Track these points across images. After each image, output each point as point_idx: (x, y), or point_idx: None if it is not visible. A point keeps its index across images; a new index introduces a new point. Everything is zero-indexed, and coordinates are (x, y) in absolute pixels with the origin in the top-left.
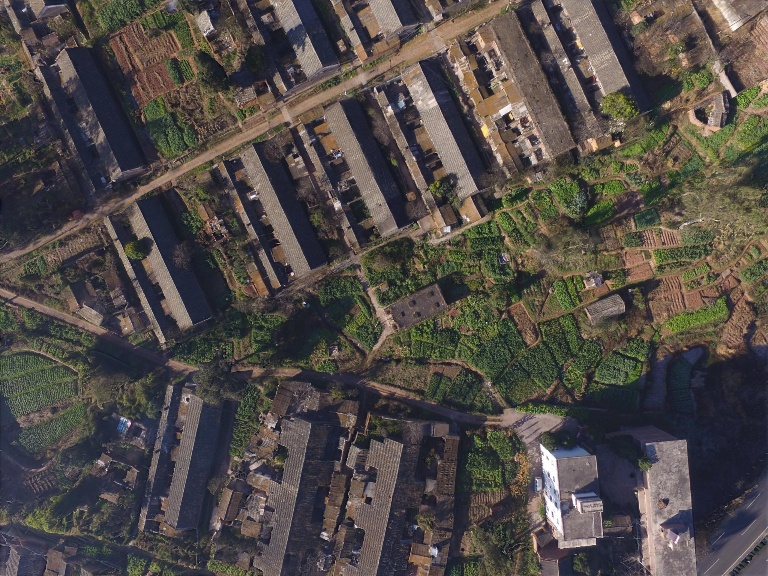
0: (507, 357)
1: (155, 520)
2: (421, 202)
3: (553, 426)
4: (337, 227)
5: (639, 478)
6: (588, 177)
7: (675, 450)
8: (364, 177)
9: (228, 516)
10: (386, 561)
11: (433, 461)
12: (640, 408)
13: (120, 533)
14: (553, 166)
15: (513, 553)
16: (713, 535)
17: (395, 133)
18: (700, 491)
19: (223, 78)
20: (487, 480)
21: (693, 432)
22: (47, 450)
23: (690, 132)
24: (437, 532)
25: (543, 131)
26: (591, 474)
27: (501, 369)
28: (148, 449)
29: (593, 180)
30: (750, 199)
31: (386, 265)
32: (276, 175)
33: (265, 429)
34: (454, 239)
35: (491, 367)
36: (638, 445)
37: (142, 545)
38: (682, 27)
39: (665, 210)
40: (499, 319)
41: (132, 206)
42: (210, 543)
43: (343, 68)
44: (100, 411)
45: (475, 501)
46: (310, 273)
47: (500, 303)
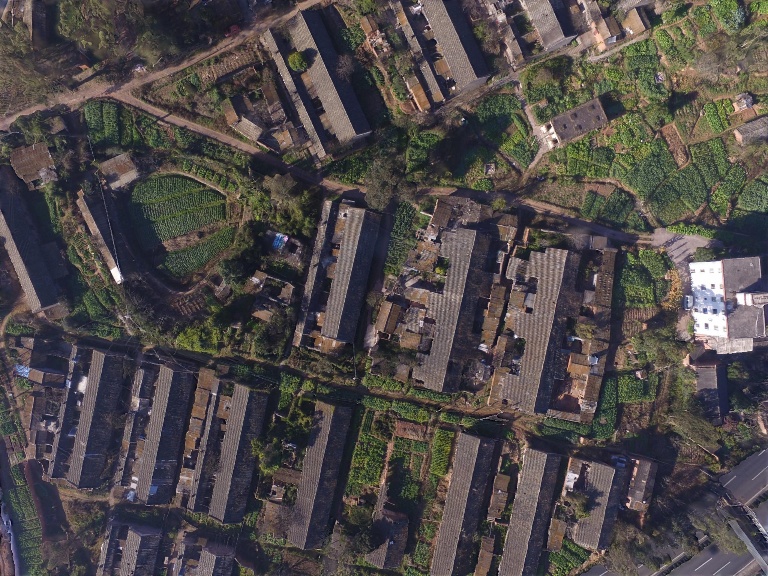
0: (660, 176)
1: (310, 336)
2: None
3: None
4: (500, 40)
5: None
6: None
7: None
8: None
9: (387, 328)
10: (548, 367)
11: None
12: None
13: (274, 350)
14: None
15: (663, 369)
16: None
17: None
18: None
19: None
20: (639, 297)
21: None
22: (193, 275)
23: None
24: (595, 342)
25: None
26: (755, 275)
27: (654, 188)
28: (303, 266)
29: None
30: None
31: (549, 78)
32: None
33: (424, 243)
34: (612, 57)
35: (645, 185)
36: None
37: (295, 364)
38: None
39: None
40: (652, 139)
41: (295, 17)
42: (365, 359)
43: None
44: (253, 229)
45: (628, 317)
46: (469, 90)
47: (661, 115)
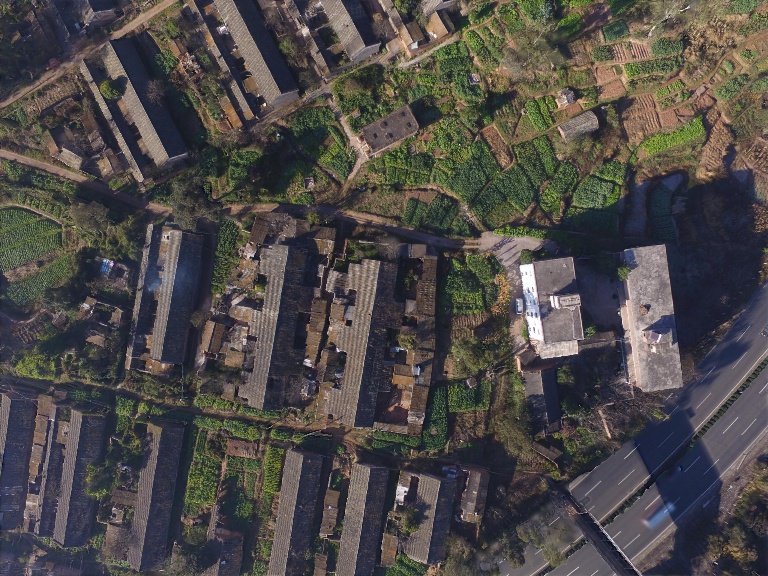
0: (482, 179)
1: (141, 359)
2: (388, 25)
3: (532, 249)
4: (306, 54)
5: (621, 294)
6: None
7: (654, 255)
8: None
9: (212, 348)
10: (369, 380)
11: (413, 285)
12: (620, 232)
13: (107, 375)
14: None
15: (497, 376)
16: (704, 369)
17: None
18: (687, 318)
19: None
20: (468, 303)
21: (676, 259)
22: (35, 303)
23: None
24: (419, 352)
25: None
26: (569, 276)
27: (477, 191)
28: (131, 290)
29: None
30: None
31: (356, 88)
32: (244, 5)
33: (245, 261)
34: (423, 62)
35: (466, 189)
36: (617, 257)
37: (130, 387)
38: None
39: (633, 21)
40: (472, 142)
41: (105, 46)
42: (196, 379)
43: None
44: (84, 256)
45: (456, 324)
46: (283, 106)
47: (471, 118)
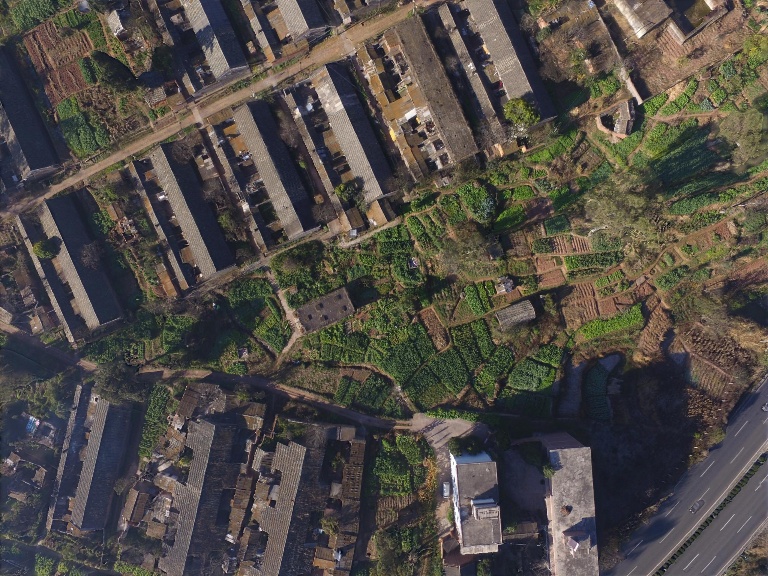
0: (416, 361)
1: (62, 520)
2: (330, 205)
3: (463, 431)
4: (245, 229)
5: (547, 485)
6: (497, 182)
7: (579, 457)
8: (271, 179)
9: (134, 517)
10: (288, 564)
11: (340, 465)
12: (553, 414)
13: (28, 532)
14: (457, 171)
15: (420, 558)
16: (631, 543)
17: (303, 136)
18: (615, 498)
19: (127, 78)
20: (395, 485)
21: (609, 439)
22: None
23: (598, 139)
24: (341, 536)
25: (446, 136)
26: (491, 480)
27: (410, 373)
28: (57, 449)
29: (502, 185)
30: (636, 207)
31: (293, 268)
32: (184, 176)
33: (172, 430)
34: (364, 242)
35: (400, 371)
36: (545, 452)
37: (50, 545)
38: (587, 33)
39: (575, 216)
40: (409, 323)
41: (41, 205)
42: (117, 544)
43: (254, 70)
44: (10, 410)
45: (382, 505)
46: (220, 275)
47: (406, 307)
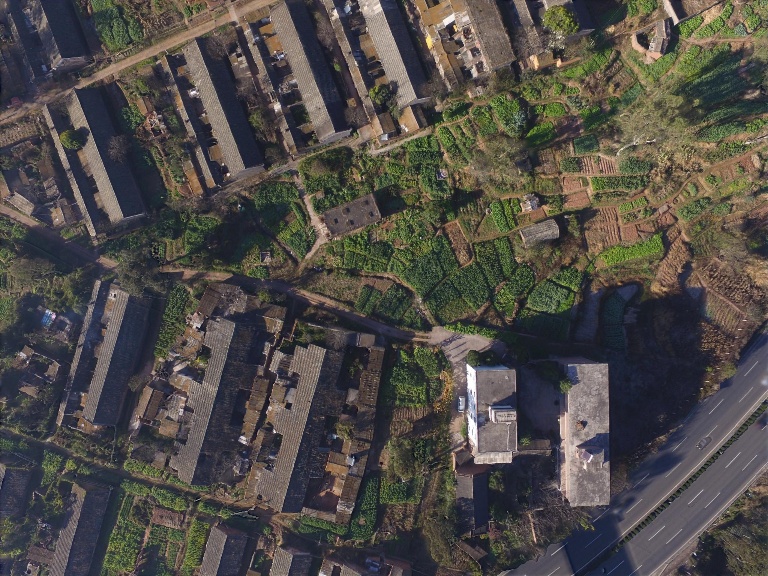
0: (439, 274)
1: (74, 416)
2: (362, 111)
3: (481, 348)
4: (276, 129)
5: (562, 403)
6: (529, 97)
7: (596, 373)
8: (305, 79)
9: (147, 414)
10: (301, 466)
11: (358, 373)
12: (570, 338)
13: (38, 427)
14: (493, 79)
15: (432, 471)
16: (638, 475)
17: (339, 38)
18: (626, 427)
19: None
20: (411, 396)
21: (623, 368)
22: None
23: (632, 58)
24: (356, 442)
25: (484, 41)
26: (509, 388)
27: (432, 286)
28: (72, 344)
29: (534, 101)
30: (673, 107)
31: (322, 170)
32: (217, 72)
33: (191, 330)
34: (393, 151)
35: (422, 283)
36: (562, 369)
37: (60, 441)
38: None
39: (604, 137)
40: (433, 236)
41: (70, 94)
42: (128, 442)
43: None
44: (26, 303)
45: (397, 416)
46: (247, 176)
47: (433, 216)
